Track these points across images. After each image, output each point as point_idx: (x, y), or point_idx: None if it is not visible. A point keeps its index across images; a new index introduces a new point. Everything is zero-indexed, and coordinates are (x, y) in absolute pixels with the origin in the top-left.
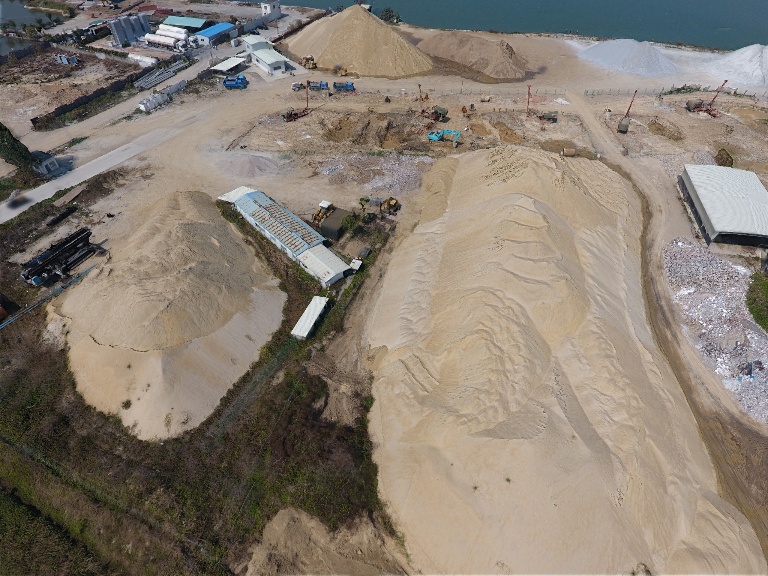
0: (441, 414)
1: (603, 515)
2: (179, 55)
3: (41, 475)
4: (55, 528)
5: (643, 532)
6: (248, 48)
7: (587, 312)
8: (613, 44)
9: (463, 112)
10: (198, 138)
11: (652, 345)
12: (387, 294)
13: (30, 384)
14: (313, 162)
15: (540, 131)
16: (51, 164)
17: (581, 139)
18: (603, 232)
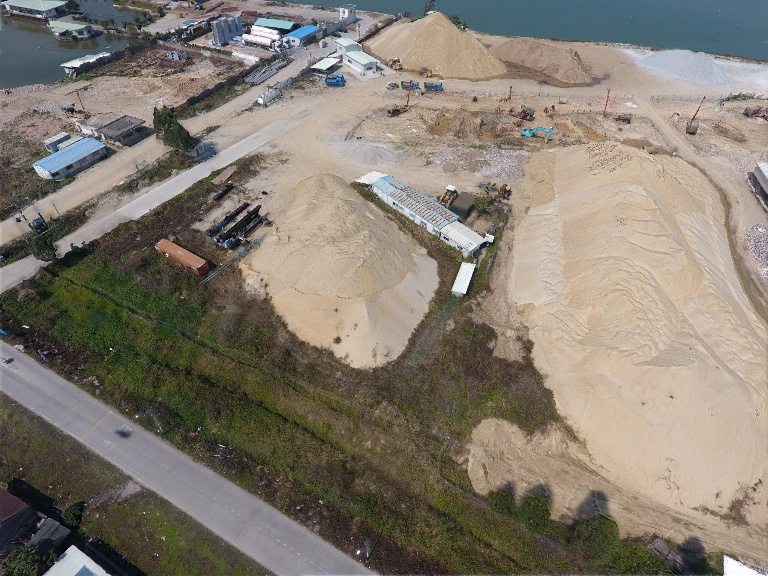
0: (604, 350)
1: (747, 425)
2: (278, 54)
3: (283, 391)
4: (304, 429)
5: None
6: (340, 49)
7: (702, 278)
8: (670, 54)
9: (545, 112)
10: (317, 129)
11: (751, 309)
12: (520, 263)
13: (249, 324)
14: (424, 153)
15: (617, 131)
16: (200, 148)
17: (655, 139)
18: (698, 217)
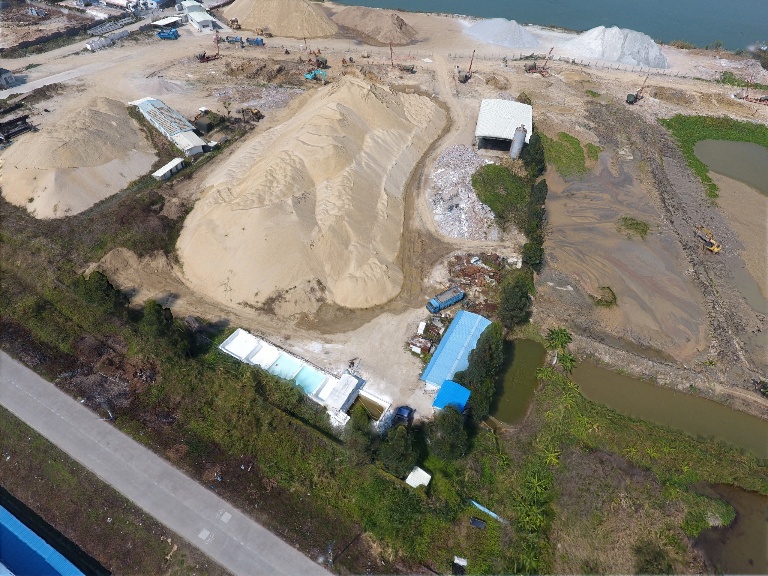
0: None
1: (296, 250)
2: (128, 13)
3: None
4: None
5: (324, 265)
6: (185, 10)
7: (347, 166)
8: (489, 22)
9: (343, 63)
10: (127, 69)
11: (398, 196)
12: None
13: None
14: (210, 88)
15: (398, 78)
16: (9, 78)
17: (427, 85)
18: (394, 132)
